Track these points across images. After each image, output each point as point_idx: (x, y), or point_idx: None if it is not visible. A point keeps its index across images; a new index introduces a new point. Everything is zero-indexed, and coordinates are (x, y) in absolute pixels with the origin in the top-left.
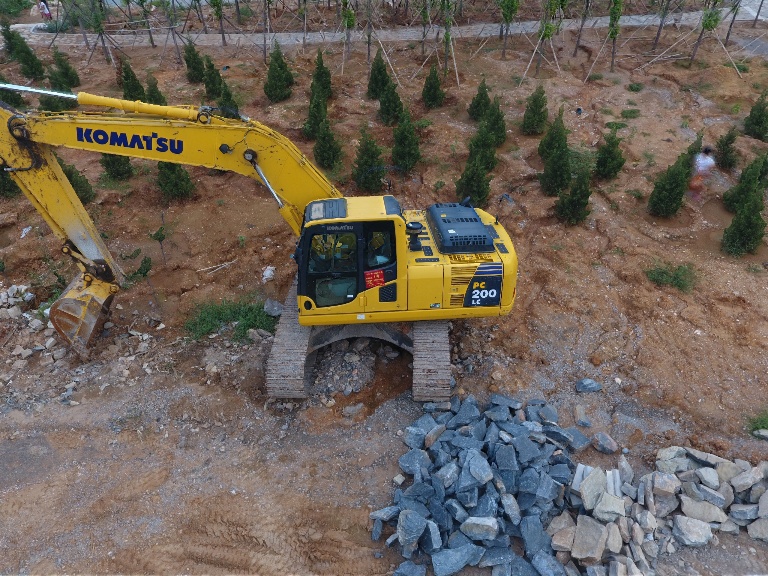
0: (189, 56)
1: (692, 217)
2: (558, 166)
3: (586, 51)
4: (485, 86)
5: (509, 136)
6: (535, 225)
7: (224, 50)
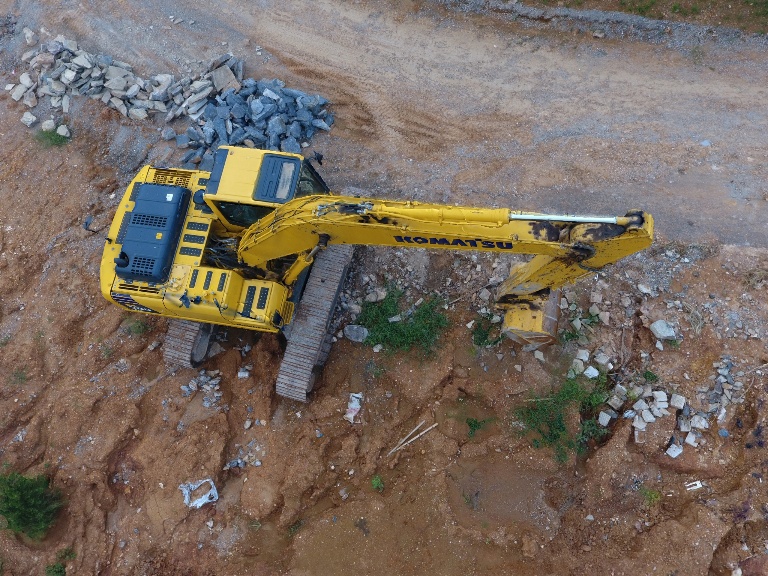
0: None
1: None
2: None
3: None
4: None
5: None
6: (1, 445)
7: None
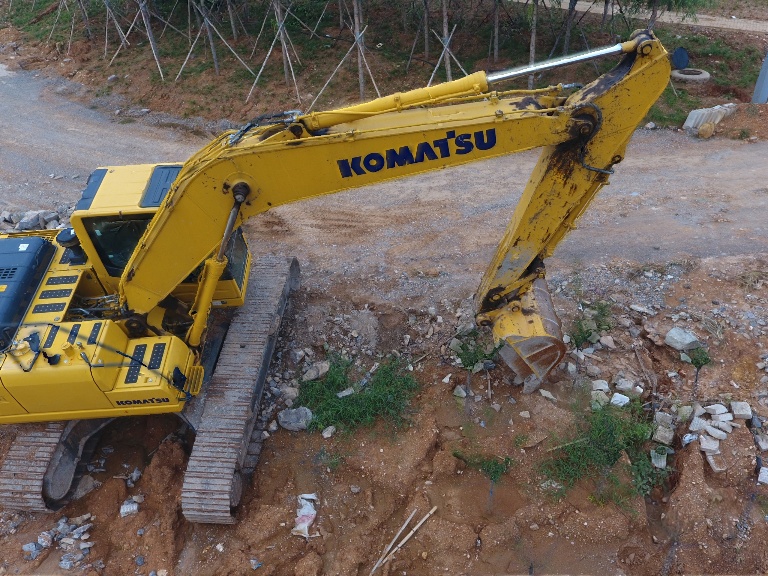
0: None
1: None
2: None
3: None
4: None
5: None
6: None
7: None
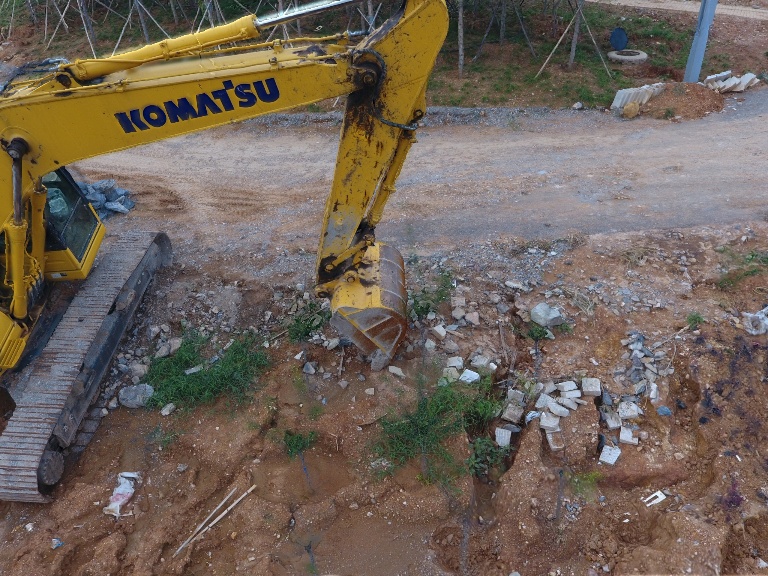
0: None
1: None
2: None
3: None
4: None
5: None
6: None
7: None
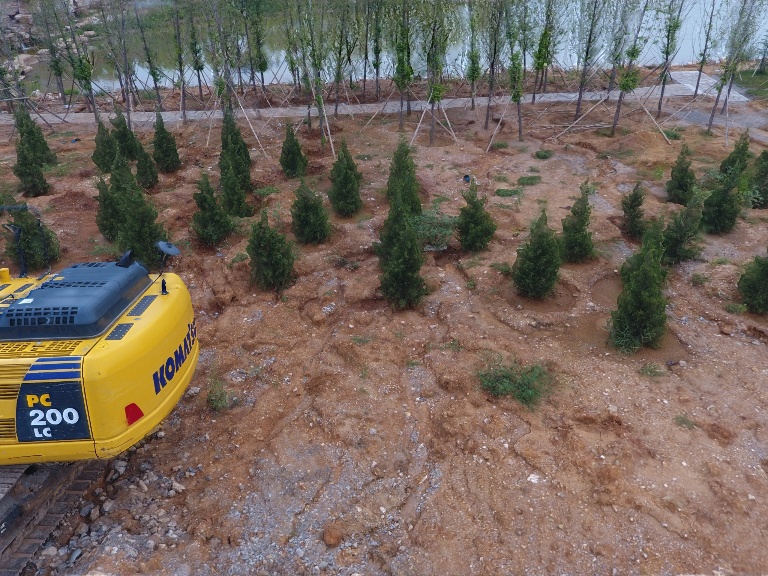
0: (21, 124)
1: (575, 298)
2: (394, 231)
3: (500, 124)
4: (346, 148)
5: (367, 204)
6: (352, 310)
7: (94, 127)
